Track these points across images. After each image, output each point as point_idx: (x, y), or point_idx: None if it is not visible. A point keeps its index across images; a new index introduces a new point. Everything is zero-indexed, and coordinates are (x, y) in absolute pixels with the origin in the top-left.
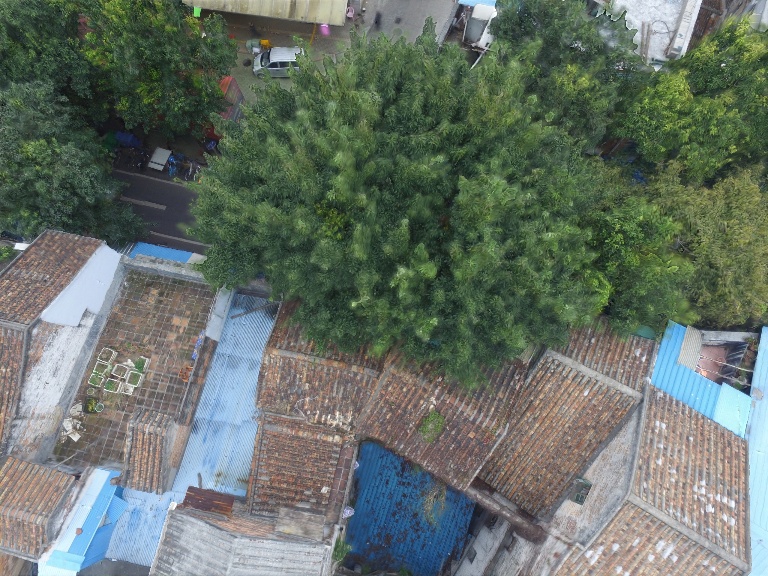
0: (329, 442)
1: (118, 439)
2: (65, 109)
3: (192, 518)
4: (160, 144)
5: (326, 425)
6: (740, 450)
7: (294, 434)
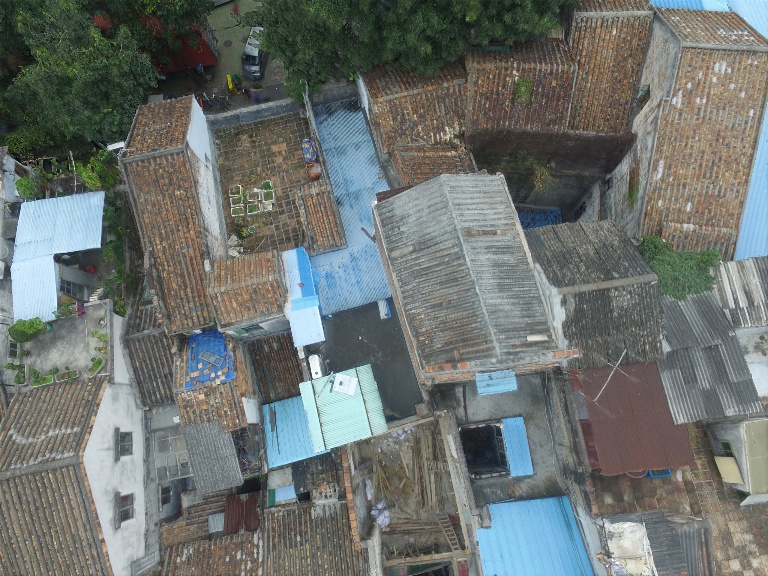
0: (449, 156)
1: (280, 244)
2: (93, 25)
3: (396, 195)
4: (147, 97)
5: (442, 143)
6: (732, 15)
7: (423, 155)
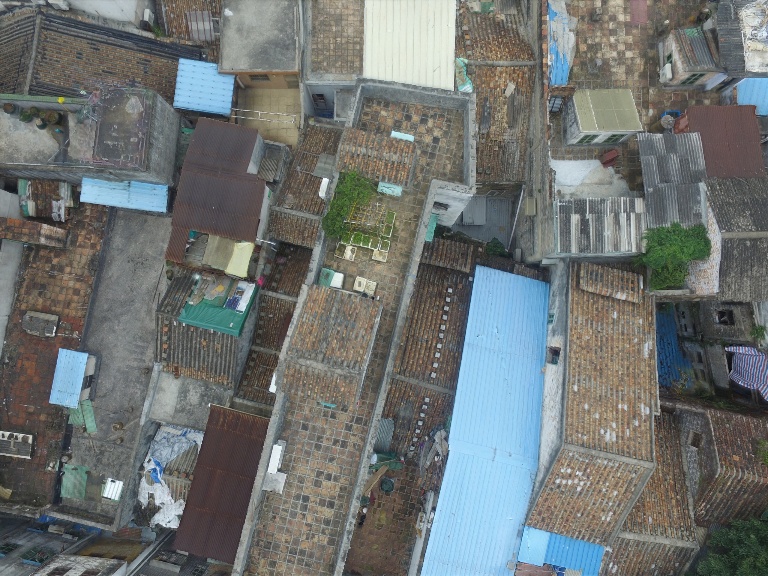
0: None
1: None
2: None
3: None
4: None
5: None
6: None
7: None
